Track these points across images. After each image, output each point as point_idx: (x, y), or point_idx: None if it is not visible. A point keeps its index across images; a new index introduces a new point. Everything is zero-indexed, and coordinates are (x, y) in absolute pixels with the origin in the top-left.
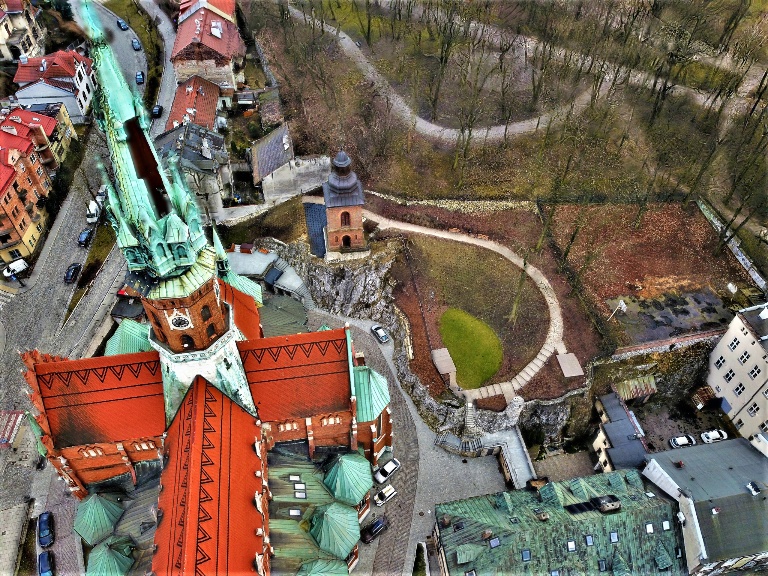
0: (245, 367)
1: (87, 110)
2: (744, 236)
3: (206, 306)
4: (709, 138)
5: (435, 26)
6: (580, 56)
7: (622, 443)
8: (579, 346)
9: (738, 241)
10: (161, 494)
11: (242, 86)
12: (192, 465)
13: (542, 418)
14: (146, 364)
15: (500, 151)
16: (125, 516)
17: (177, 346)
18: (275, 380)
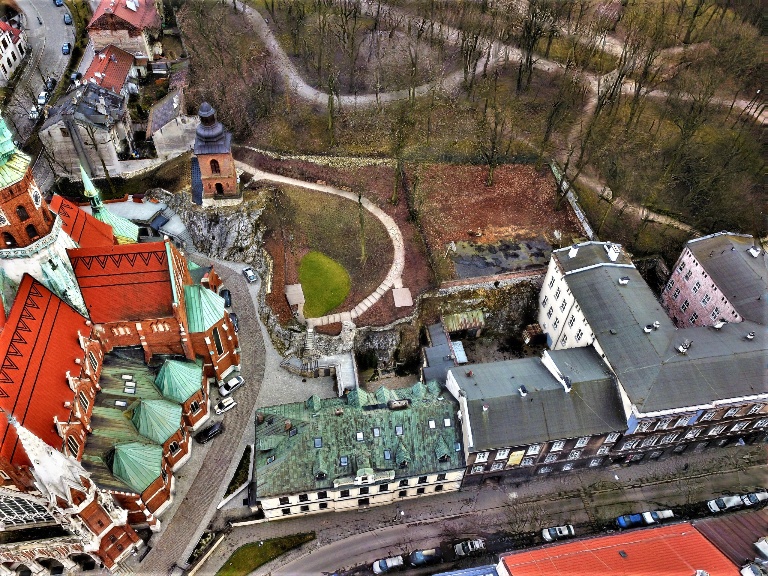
0: (76, 273)
1: (12, 76)
2: (587, 194)
3: (22, 207)
4: (573, 110)
5: None
6: (472, 36)
7: (437, 363)
8: (414, 282)
9: (576, 197)
10: None
11: (158, 57)
12: (0, 339)
13: (375, 343)
14: None
15: (374, 115)
16: None
17: (1, 243)
18: (104, 286)
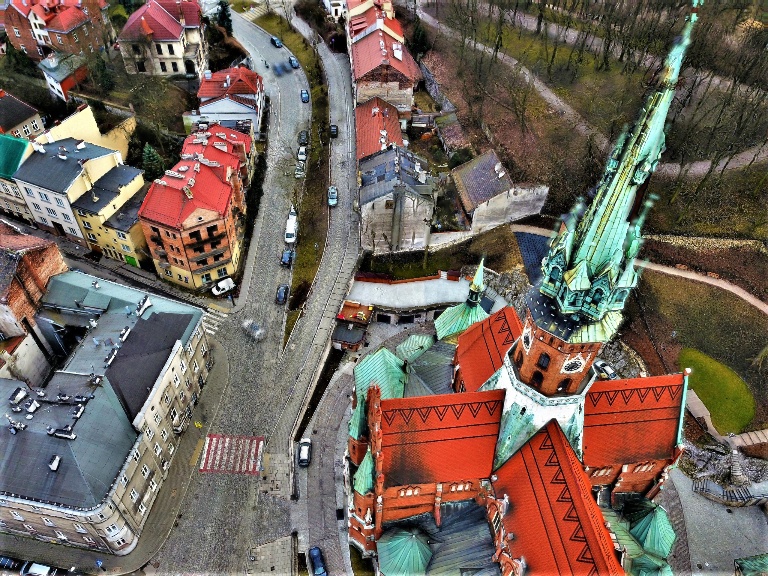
0: None
1: (260, 127)
2: None
3: None
4: None
5: (611, 56)
6: None
7: None
8: None
9: None
10: (512, 543)
11: (414, 109)
12: (591, 518)
13: None
14: (487, 404)
15: (714, 187)
16: (435, 560)
17: (552, 389)
18: (606, 425)
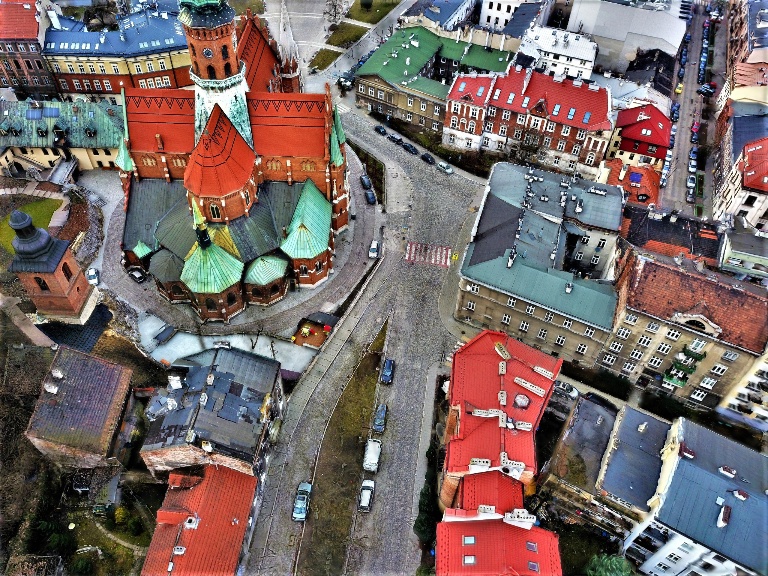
0: None
1: None
2: None
3: None
4: None
5: None
6: None
7: None
8: None
9: None
10: None
11: None
12: None
13: None
14: None
15: None
16: None
17: None
18: None
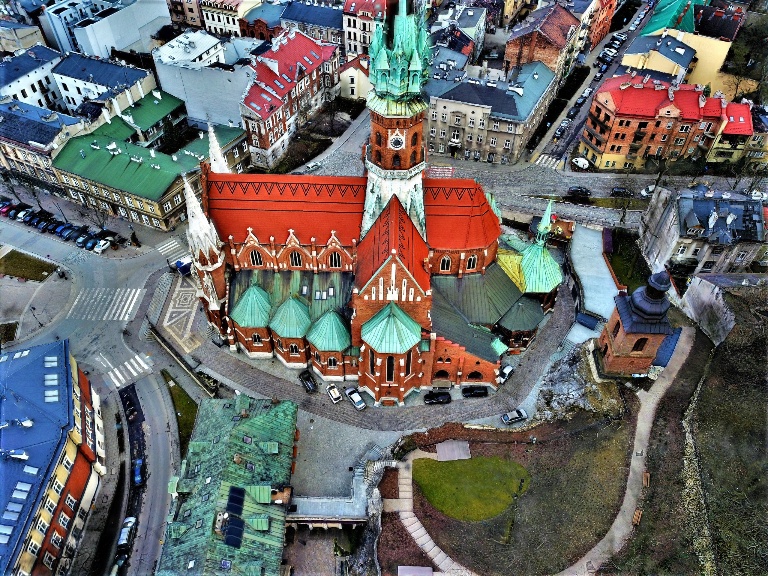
0: None
1: None
2: None
3: (380, 135)
4: None
5: None
6: None
7: None
8: None
9: None
10: None
11: None
12: None
13: None
14: None
15: None
16: None
17: None
18: None
